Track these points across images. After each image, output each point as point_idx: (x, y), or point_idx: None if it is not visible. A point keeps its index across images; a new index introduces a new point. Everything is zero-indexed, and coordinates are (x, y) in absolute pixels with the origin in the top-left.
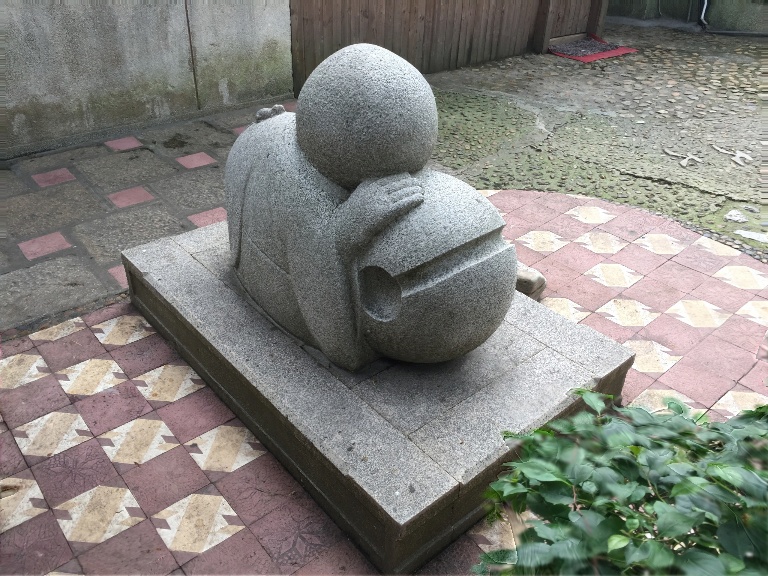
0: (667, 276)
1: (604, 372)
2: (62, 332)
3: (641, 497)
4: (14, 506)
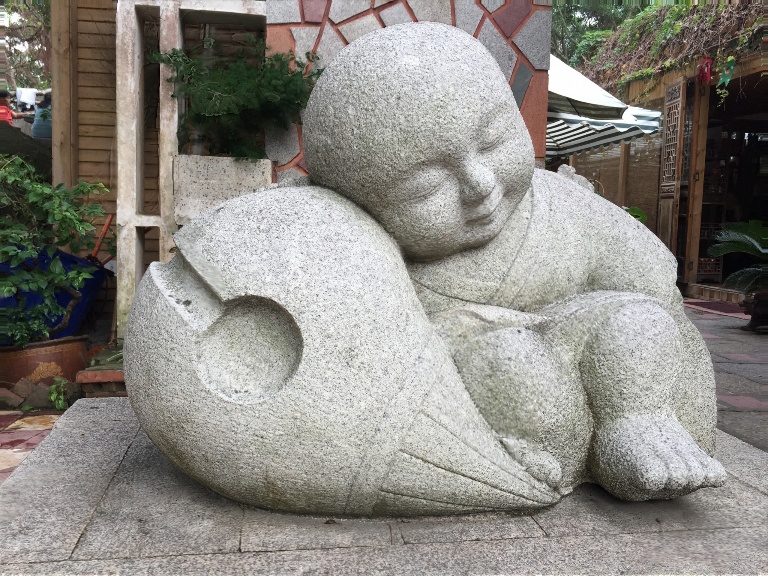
0: None
1: None
2: None
3: None
4: None
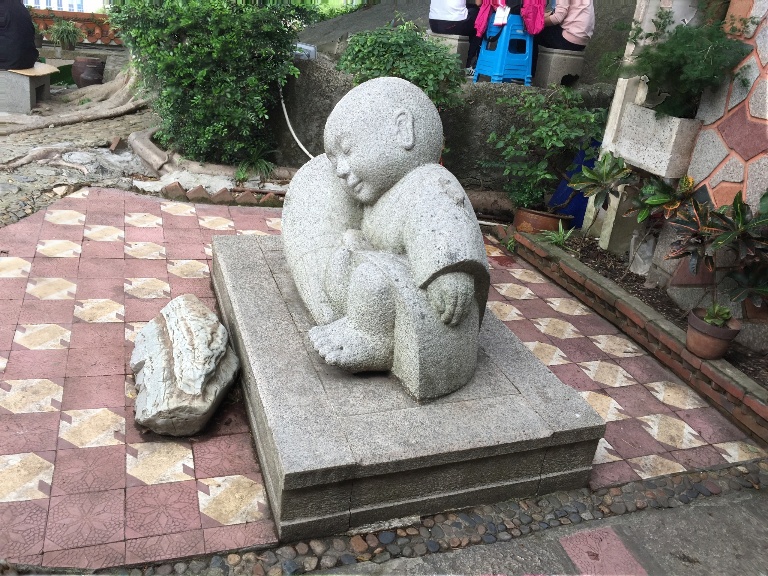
0: (2, 315)
1: (248, 235)
2: (651, 462)
3: (436, 53)
4: (608, 343)
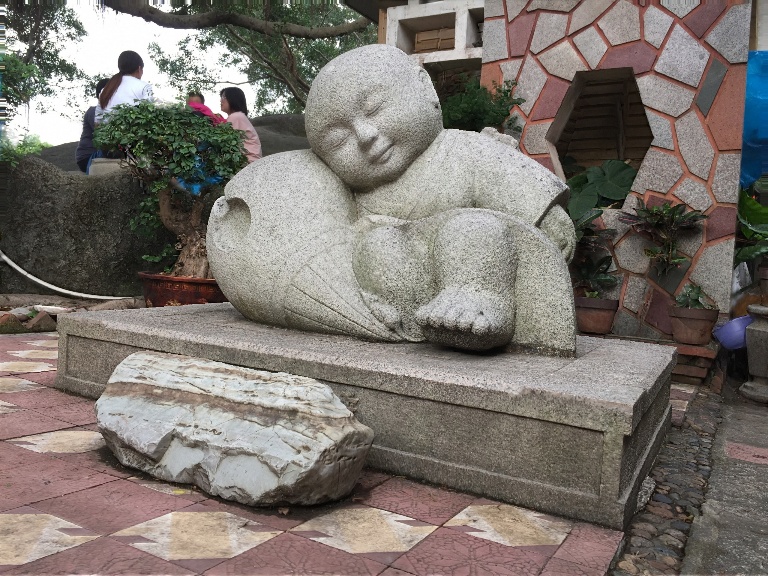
0: None
1: None
2: None
3: None
4: None
